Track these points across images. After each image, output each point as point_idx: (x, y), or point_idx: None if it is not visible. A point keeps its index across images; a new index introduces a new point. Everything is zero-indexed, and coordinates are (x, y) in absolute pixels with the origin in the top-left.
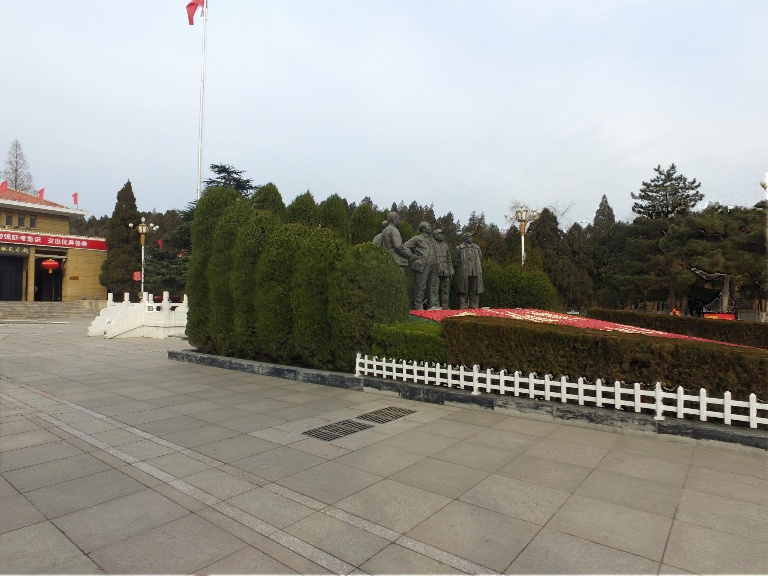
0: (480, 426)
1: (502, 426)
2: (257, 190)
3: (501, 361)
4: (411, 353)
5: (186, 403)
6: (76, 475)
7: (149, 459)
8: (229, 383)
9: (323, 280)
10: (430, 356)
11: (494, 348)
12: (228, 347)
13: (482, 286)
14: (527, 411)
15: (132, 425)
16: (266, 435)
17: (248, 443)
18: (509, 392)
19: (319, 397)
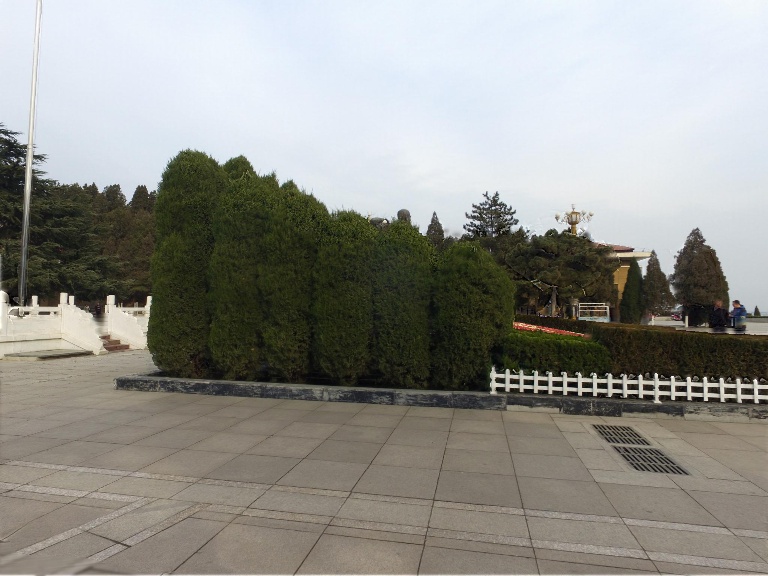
0: (723, 435)
1: (736, 432)
2: (228, 162)
3: (674, 368)
4: (566, 364)
5: (380, 452)
6: None
7: (641, 545)
8: (332, 417)
9: (426, 282)
10: (590, 366)
11: (669, 355)
12: (242, 368)
13: None
14: (721, 415)
15: (432, 498)
16: (622, 479)
17: (644, 494)
18: (697, 398)
19: (493, 423)
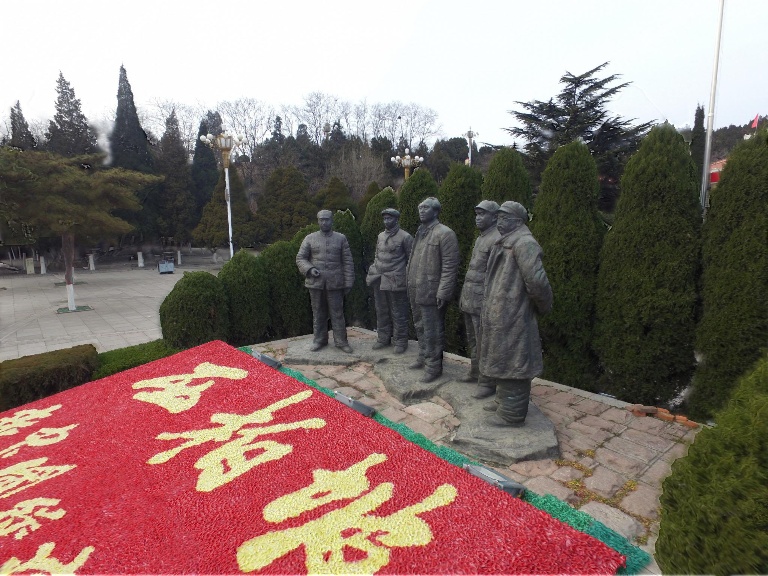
0: None
1: None
2: None
3: None
4: None
5: None
6: (109, 348)
7: None
8: None
9: None
10: None
11: None
12: None
13: (493, 359)
14: None
15: None
16: None
17: None
18: None
19: None
